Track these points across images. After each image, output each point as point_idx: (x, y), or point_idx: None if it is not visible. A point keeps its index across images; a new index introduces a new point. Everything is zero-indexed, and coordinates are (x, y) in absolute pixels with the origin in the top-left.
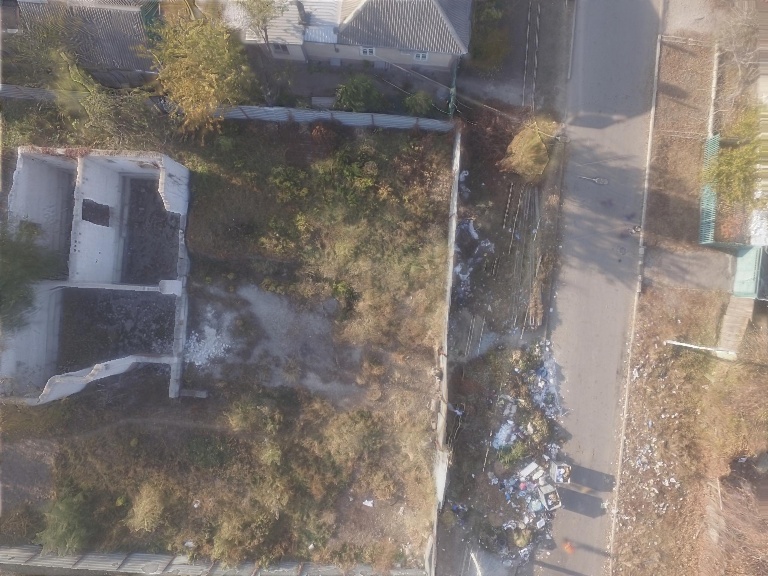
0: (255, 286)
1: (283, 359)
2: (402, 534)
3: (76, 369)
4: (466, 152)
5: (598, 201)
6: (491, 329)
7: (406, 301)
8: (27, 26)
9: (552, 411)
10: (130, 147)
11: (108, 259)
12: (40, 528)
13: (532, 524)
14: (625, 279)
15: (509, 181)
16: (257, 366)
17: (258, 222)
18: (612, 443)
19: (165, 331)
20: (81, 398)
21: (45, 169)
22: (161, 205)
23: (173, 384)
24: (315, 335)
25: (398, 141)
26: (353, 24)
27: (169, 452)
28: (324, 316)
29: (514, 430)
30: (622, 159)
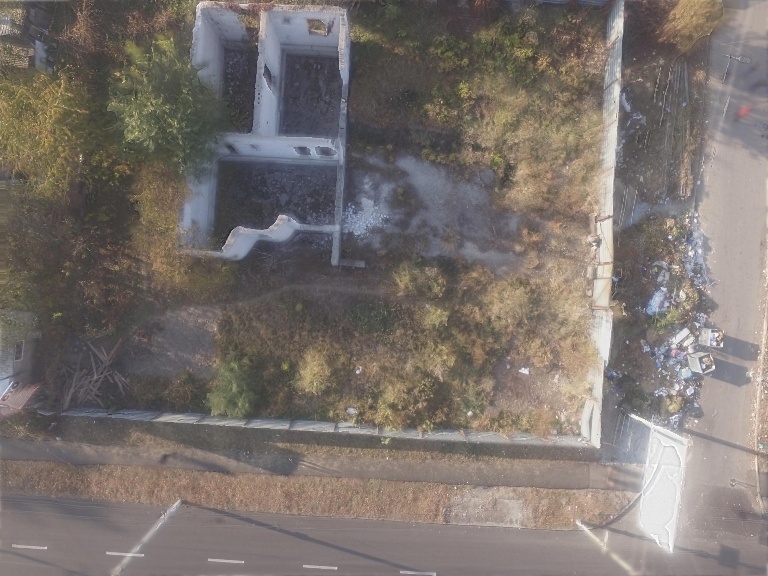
0: (413, 158)
1: (441, 229)
2: (557, 401)
3: None
4: (627, 20)
5: (742, 78)
6: (643, 199)
7: (563, 171)
8: None
9: (700, 281)
10: (316, 0)
11: (272, 126)
12: (203, 394)
13: (682, 391)
14: (767, 154)
15: (658, 57)
16: (415, 236)
17: (419, 92)
18: (756, 313)
19: (320, 205)
20: (243, 265)
21: (212, 35)
22: (315, 81)
23: (335, 251)
24: (472, 205)
25: (554, 15)
26: None
27: (332, 318)
28: (481, 187)
29: (668, 296)
30: (763, 39)
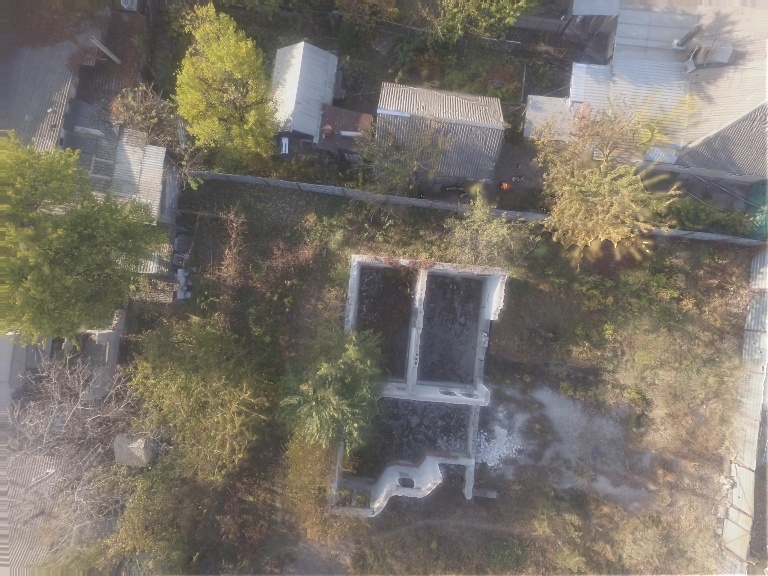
0: (549, 389)
1: (574, 462)
2: None
3: (371, 468)
4: None
5: None
6: None
7: (700, 410)
8: (375, 135)
9: None
10: (480, 264)
11: None
12: None
13: None
14: None
15: None
16: (549, 468)
17: (562, 328)
18: None
19: (451, 428)
20: None
21: None
22: (450, 302)
23: (471, 486)
24: (606, 439)
25: (700, 253)
26: (698, 149)
27: (466, 554)
28: (616, 421)
29: None
30: None
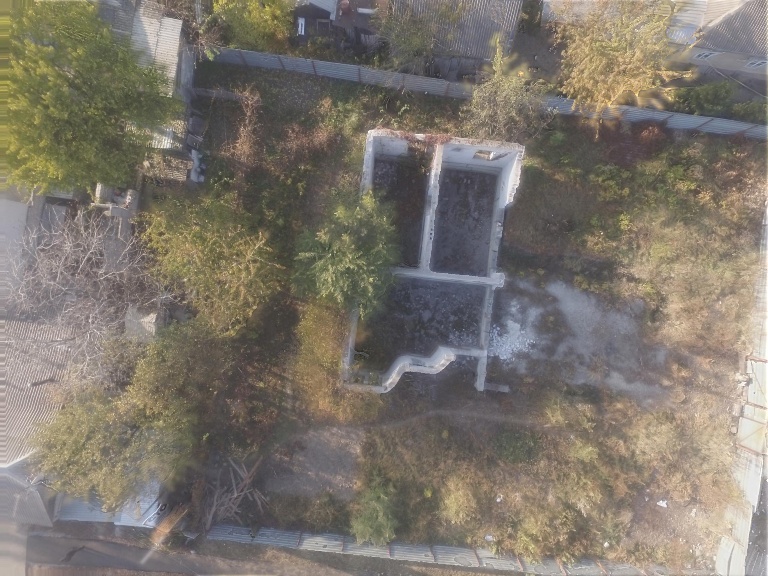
0: (563, 283)
1: (587, 357)
2: (693, 535)
3: (382, 358)
4: None
5: None
6: None
7: (716, 306)
8: (393, 7)
9: None
10: (497, 137)
11: None
12: (344, 517)
13: None
14: None
15: None
16: (562, 363)
17: (577, 219)
18: None
19: (463, 323)
20: None
21: (373, 153)
22: (464, 196)
23: (483, 377)
24: (620, 335)
25: (718, 146)
26: (719, 28)
27: (477, 445)
28: (631, 316)
29: None
30: None
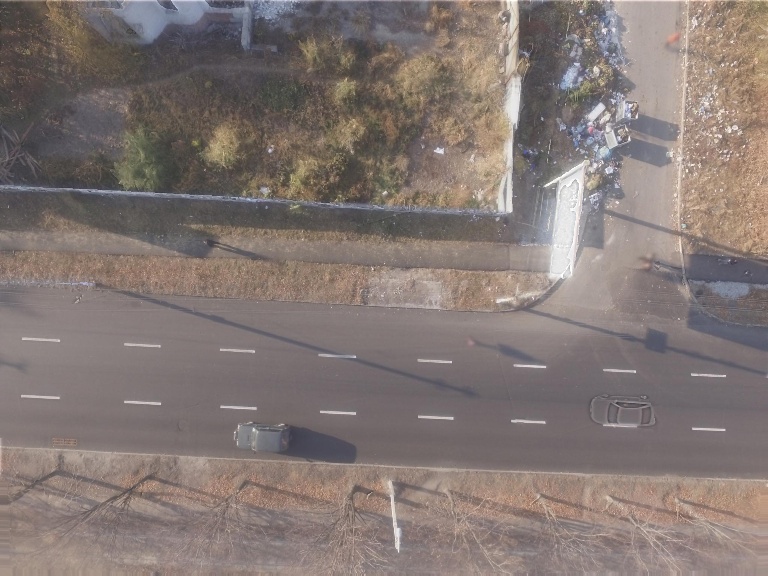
0: None
1: (352, 13)
2: (474, 181)
3: None
4: None
5: None
6: None
7: None
8: None
9: (615, 61)
10: None
11: None
12: None
13: (601, 169)
14: None
15: None
16: (326, 19)
17: None
18: (674, 93)
19: None
20: None
21: None
22: None
23: (245, 32)
24: None
25: None
26: None
27: (243, 96)
28: None
29: (581, 70)
30: None
